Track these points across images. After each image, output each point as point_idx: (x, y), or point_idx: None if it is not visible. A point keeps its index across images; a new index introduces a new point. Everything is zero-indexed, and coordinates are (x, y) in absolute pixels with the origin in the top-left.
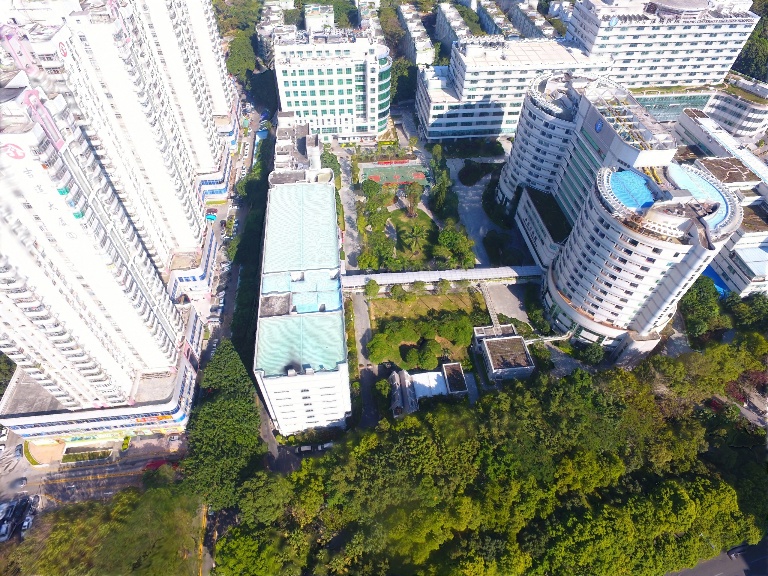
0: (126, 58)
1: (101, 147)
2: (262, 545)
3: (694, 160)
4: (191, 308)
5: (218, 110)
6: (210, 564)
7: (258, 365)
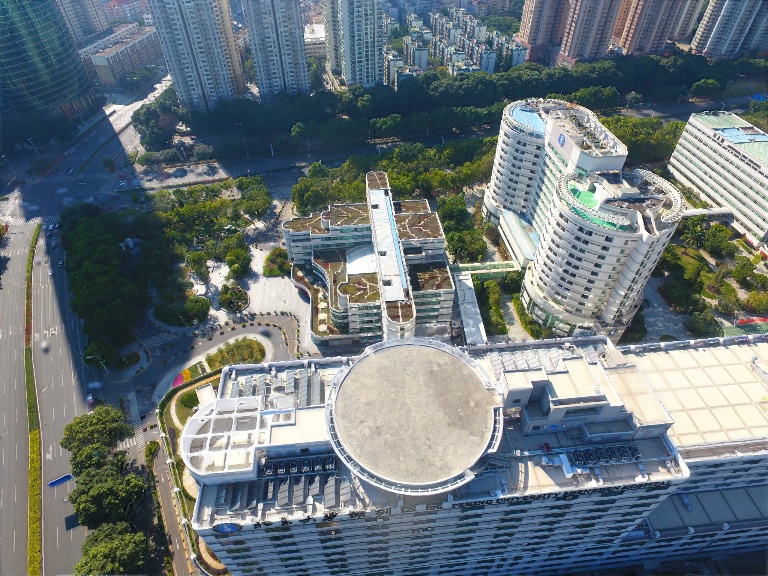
0: None
1: None
2: (677, 127)
3: (424, 270)
4: None
5: None
6: None
7: None
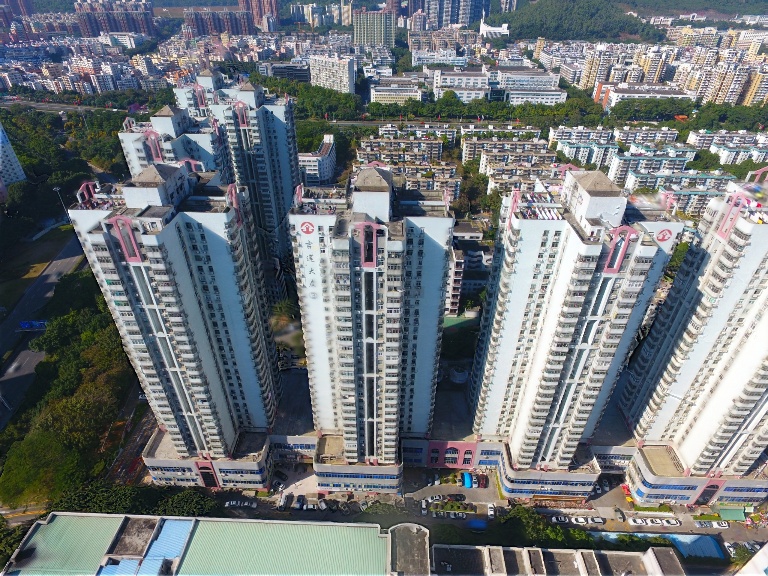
0: (335, 272)
1: (302, 308)
2: None
3: None
4: (252, 461)
5: (682, 453)
6: (21, 520)
7: (61, 518)
